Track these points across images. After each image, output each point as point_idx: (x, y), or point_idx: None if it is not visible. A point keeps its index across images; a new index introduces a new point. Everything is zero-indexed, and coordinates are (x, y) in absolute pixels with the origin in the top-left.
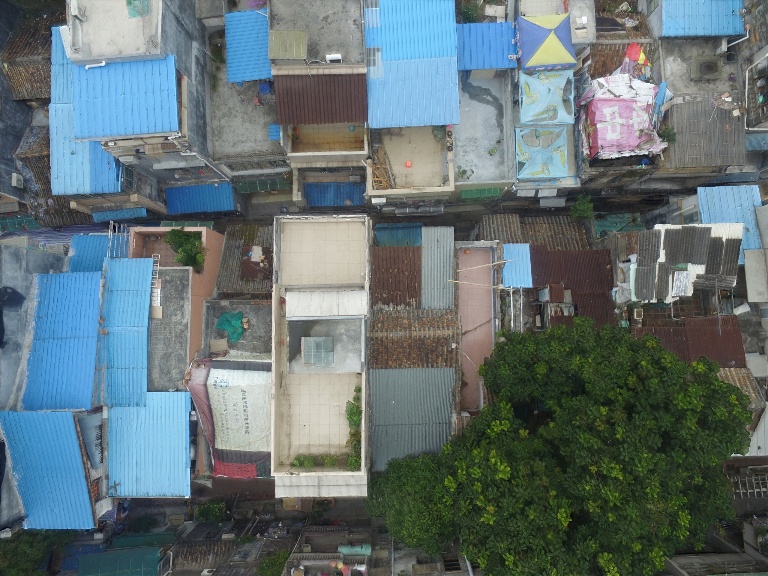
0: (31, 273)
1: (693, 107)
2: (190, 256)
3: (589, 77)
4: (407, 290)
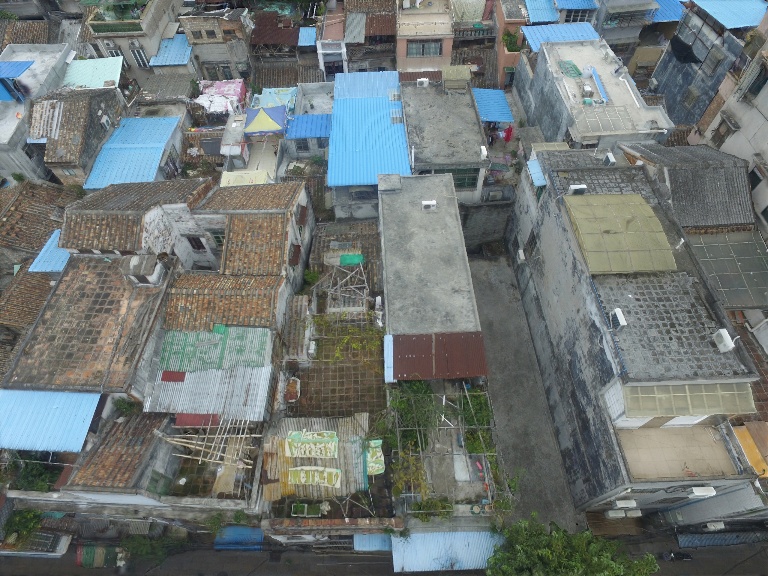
0: (601, 5)
1: (173, 95)
2: (511, 36)
3: (238, 113)
4: (374, 19)
